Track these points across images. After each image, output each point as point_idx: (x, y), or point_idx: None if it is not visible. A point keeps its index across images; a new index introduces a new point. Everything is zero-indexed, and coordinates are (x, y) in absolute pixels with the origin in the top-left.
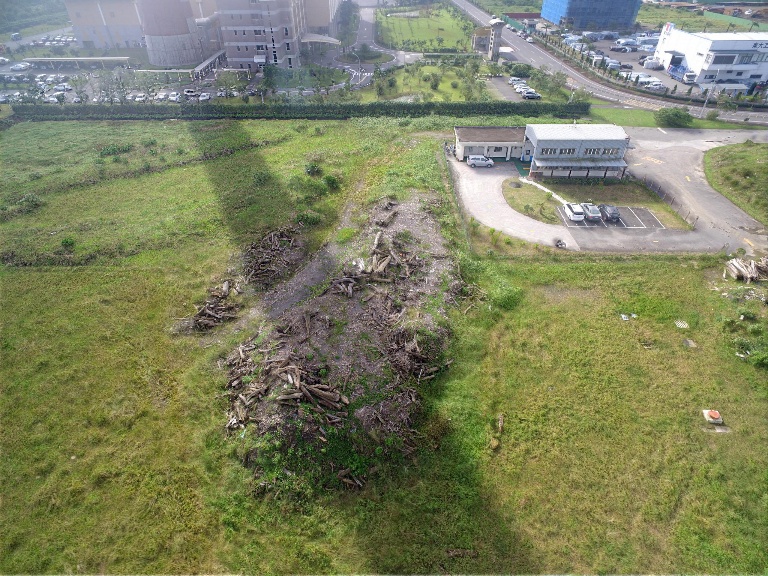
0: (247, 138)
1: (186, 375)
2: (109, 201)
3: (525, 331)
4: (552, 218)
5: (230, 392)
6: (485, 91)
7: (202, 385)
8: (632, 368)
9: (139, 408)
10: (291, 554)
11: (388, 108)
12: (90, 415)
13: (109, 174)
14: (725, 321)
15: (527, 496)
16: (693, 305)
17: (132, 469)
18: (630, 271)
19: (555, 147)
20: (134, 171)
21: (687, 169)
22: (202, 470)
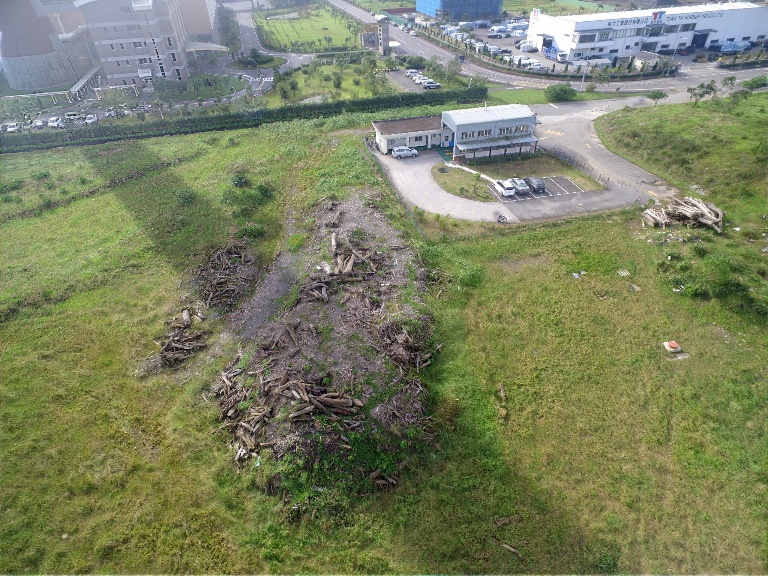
0: (156, 157)
1: (171, 416)
2: (12, 246)
3: (496, 304)
4: (486, 196)
5: (228, 423)
6: (387, 85)
7: (193, 423)
8: (596, 319)
9: (128, 463)
10: (347, 569)
11: (298, 111)
12: (70, 485)
13: (2, 216)
14: (657, 263)
15: (547, 453)
16: (627, 255)
17: (141, 530)
18: (568, 234)
19: (473, 130)
20: (33, 209)
21: (585, 137)
22: (223, 511)
